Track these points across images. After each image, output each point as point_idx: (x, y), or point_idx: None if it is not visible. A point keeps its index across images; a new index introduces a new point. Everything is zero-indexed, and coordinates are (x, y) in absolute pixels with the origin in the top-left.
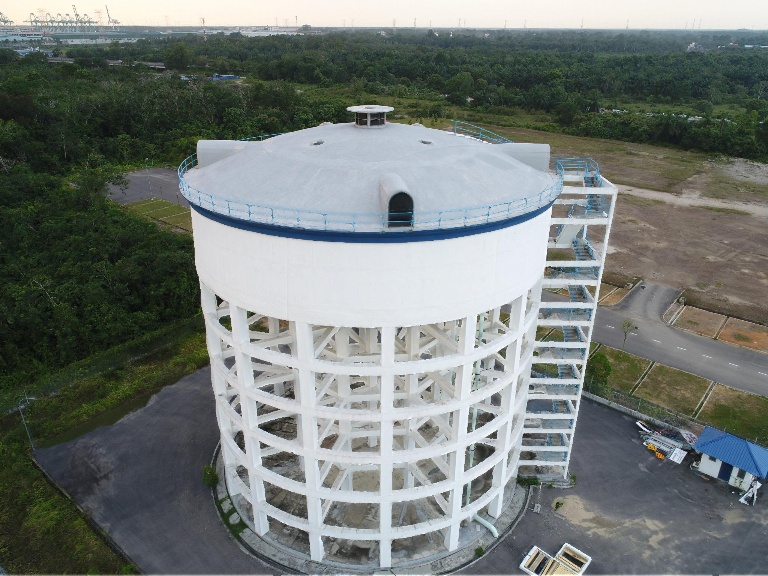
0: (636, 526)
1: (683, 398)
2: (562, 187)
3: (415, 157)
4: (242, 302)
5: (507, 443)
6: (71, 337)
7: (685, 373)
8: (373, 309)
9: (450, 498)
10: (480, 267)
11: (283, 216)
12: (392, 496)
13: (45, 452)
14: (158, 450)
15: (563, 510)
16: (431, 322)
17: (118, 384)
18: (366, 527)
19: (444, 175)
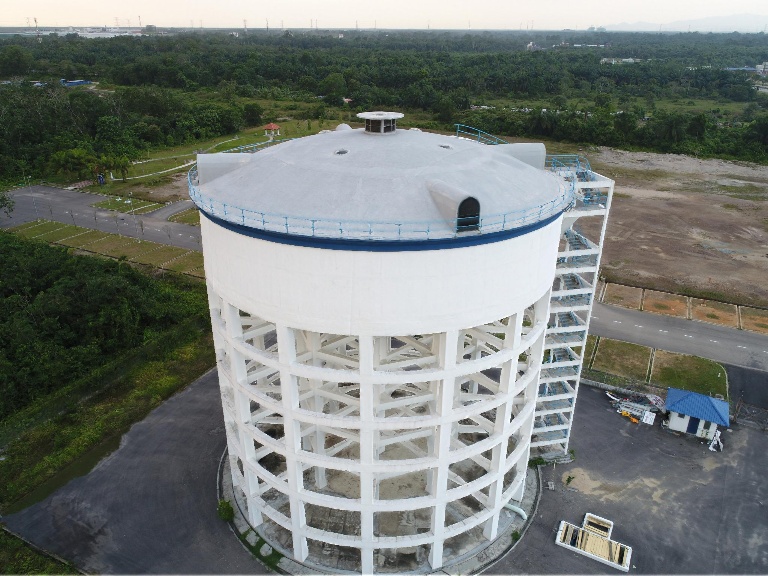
0: (638, 486)
1: (634, 366)
2: (569, 183)
3: (446, 162)
4: (295, 322)
5: (531, 428)
6: (9, 384)
7: (628, 343)
8: (440, 314)
9: (492, 489)
10: (528, 264)
11: (346, 229)
12: (447, 497)
13: (16, 518)
14: (152, 493)
15: (574, 483)
16: (489, 321)
17: (79, 429)
18: (404, 533)
19: (481, 178)
